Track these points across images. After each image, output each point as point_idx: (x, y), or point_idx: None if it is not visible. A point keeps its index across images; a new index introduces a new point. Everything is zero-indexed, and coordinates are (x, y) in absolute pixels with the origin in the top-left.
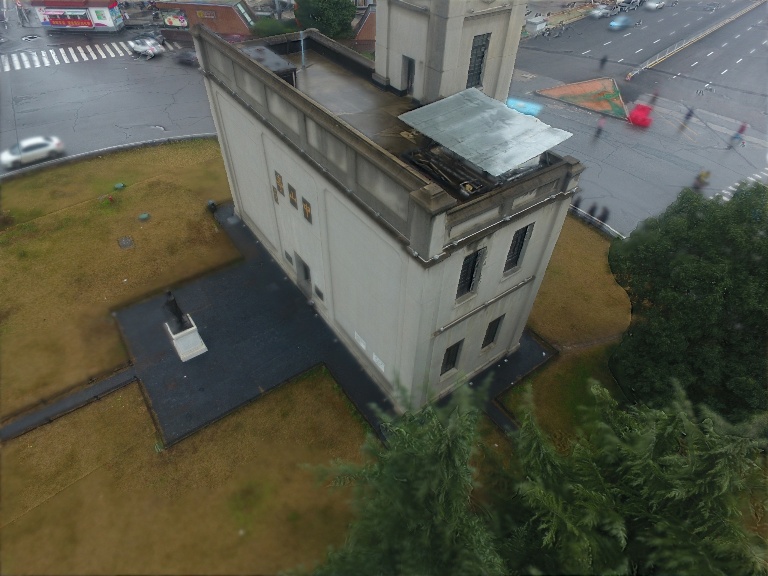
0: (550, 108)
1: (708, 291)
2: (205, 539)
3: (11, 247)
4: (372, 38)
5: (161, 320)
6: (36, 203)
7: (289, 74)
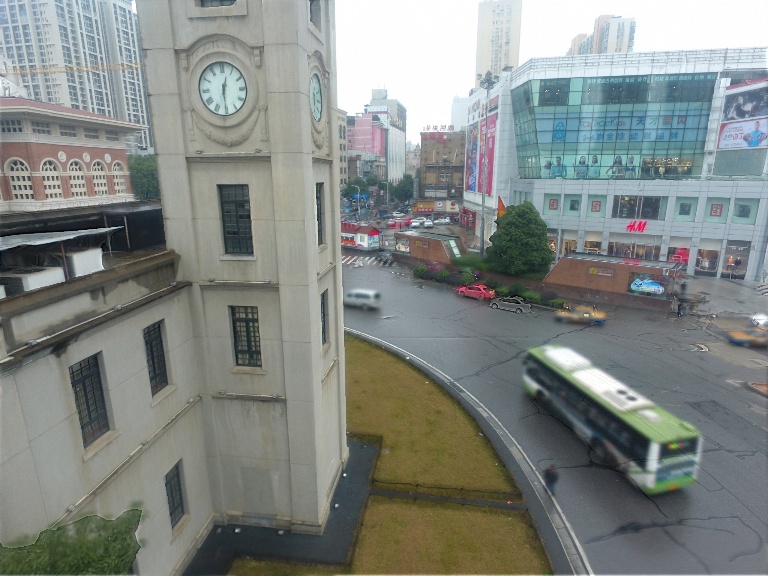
0: (752, 411)
1: None
2: None
3: None
4: (562, 283)
5: None
6: None
7: (122, 218)
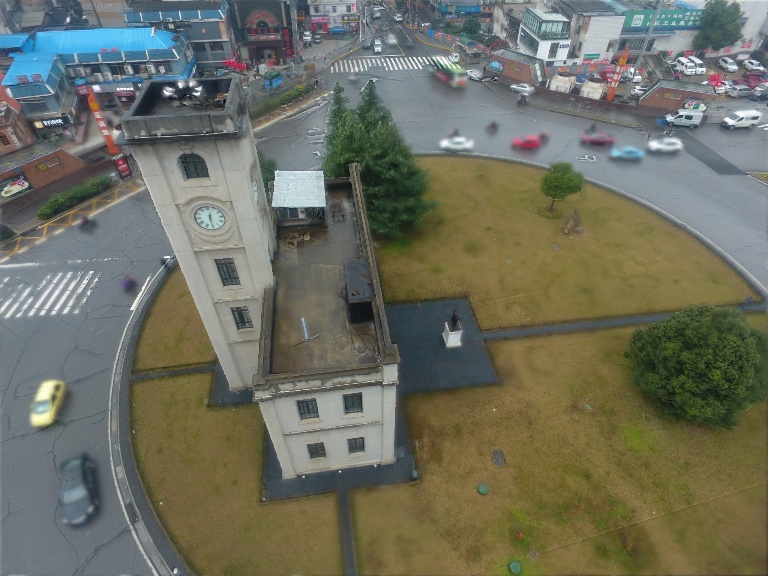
0: None
1: (271, 172)
2: (454, 264)
3: (603, 492)
4: None
5: (468, 365)
6: (609, 574)
7: None
